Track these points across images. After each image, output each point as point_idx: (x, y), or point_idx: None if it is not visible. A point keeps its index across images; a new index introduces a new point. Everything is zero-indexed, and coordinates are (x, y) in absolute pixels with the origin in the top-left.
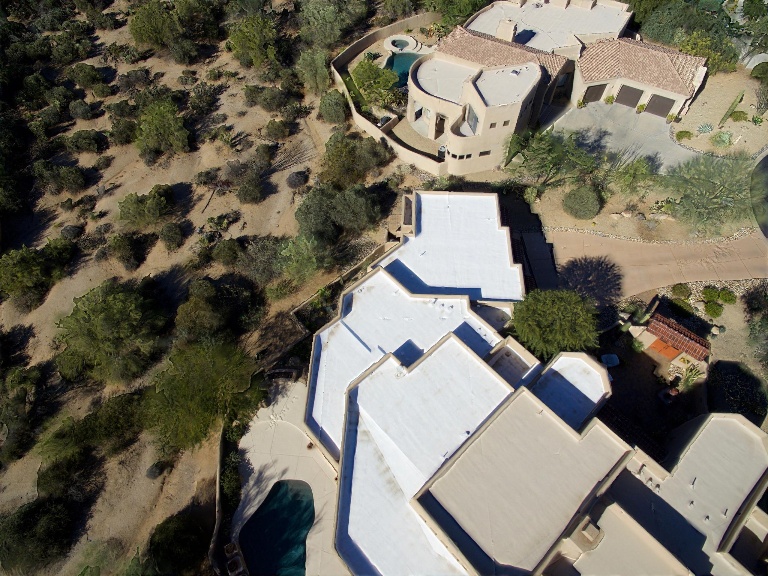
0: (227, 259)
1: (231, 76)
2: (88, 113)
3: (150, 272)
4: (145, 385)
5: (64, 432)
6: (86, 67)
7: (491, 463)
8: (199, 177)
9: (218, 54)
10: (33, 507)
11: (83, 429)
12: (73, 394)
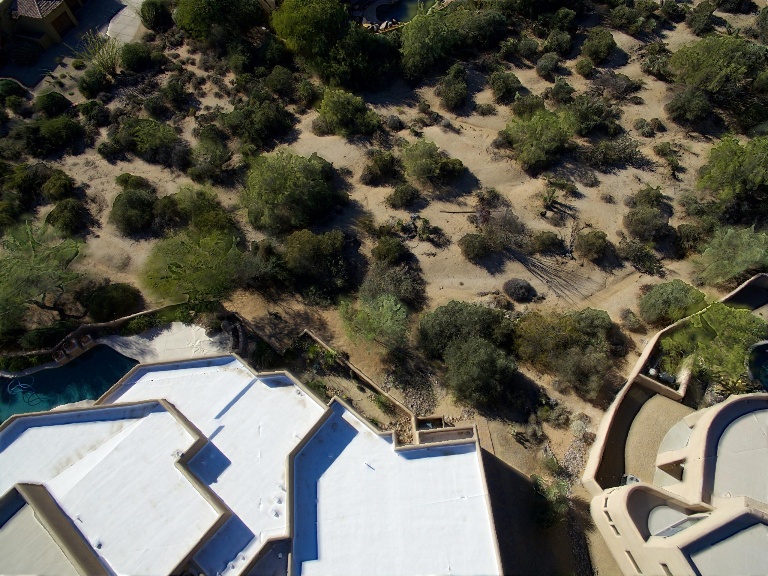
0: (376, 252)
1: (672, 166)
2: (544, 70)
3: (361, 195)
4: (247, 234)
5: (200, 196)
6: (607, 39)
7: (42, 575)
8: (489, 192)
9: (714, 139)
10: (146, 202)
11: (200, 206)
12: (241, 189)
